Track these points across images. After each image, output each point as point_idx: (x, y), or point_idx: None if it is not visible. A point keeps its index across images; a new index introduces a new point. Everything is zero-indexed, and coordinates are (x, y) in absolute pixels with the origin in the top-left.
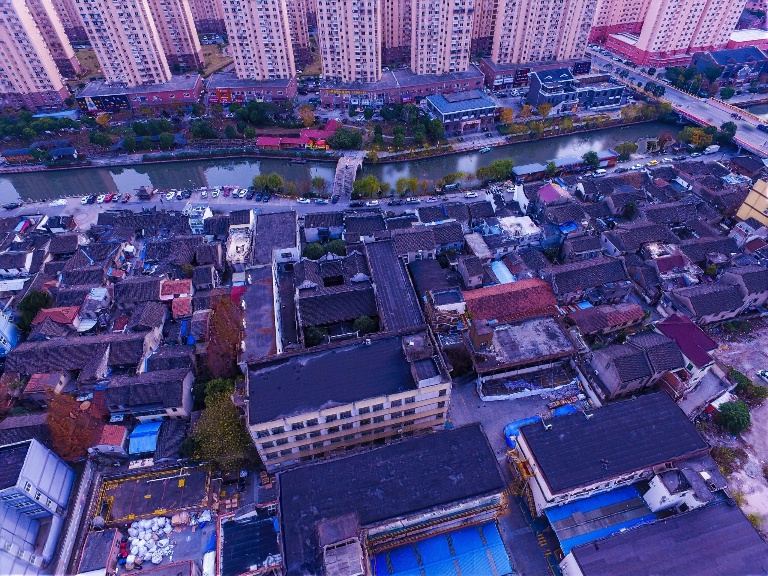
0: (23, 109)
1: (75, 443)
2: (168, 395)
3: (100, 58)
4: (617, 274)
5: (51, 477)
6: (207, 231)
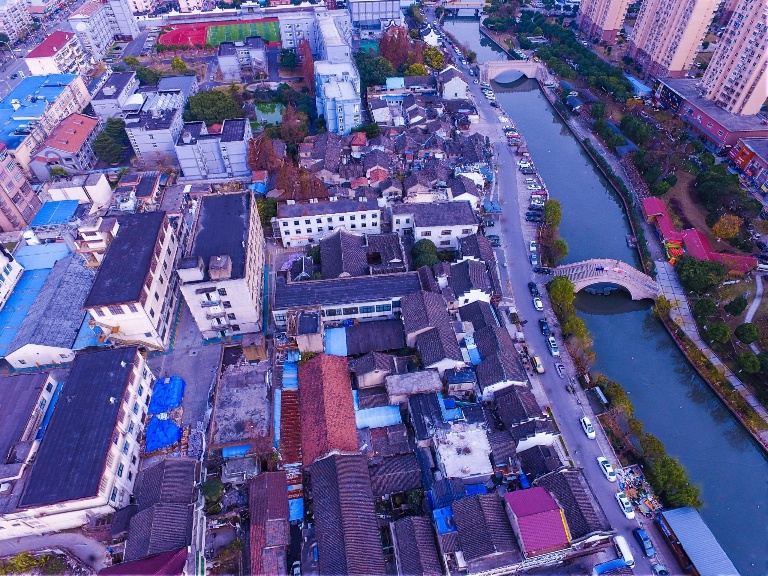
0: (638, 70)
1: (249, 160)
2: (272, 185)
3: (712, 59)
4: (329, 572)
5: (239, 162)
6: (450, 181)
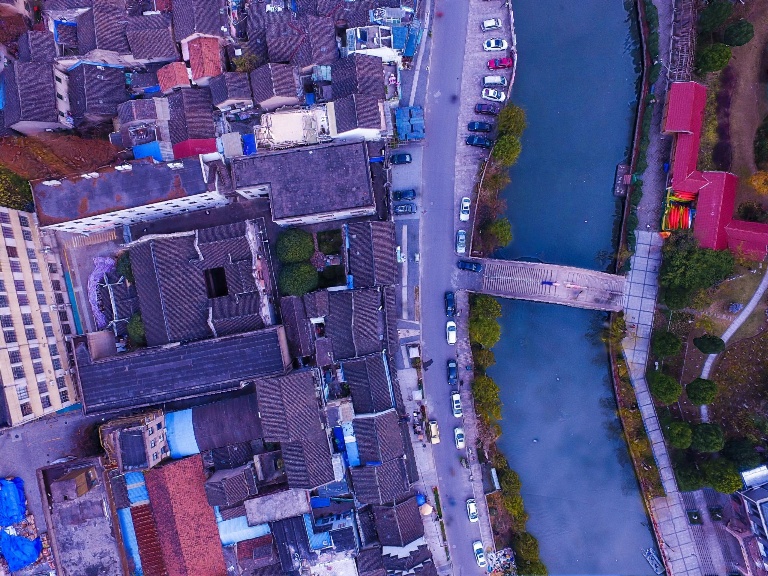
0: None
1: None
2: (11, 108)
3: None
4: None
5: None
6: (336, 65)
